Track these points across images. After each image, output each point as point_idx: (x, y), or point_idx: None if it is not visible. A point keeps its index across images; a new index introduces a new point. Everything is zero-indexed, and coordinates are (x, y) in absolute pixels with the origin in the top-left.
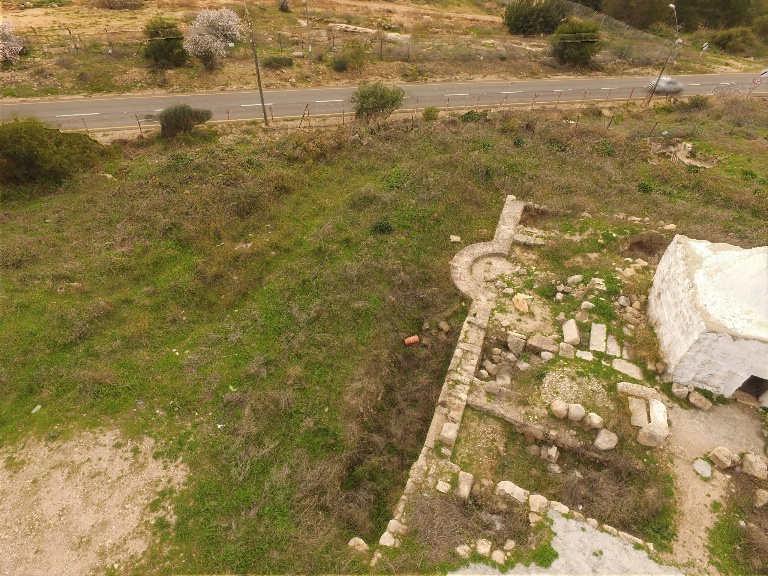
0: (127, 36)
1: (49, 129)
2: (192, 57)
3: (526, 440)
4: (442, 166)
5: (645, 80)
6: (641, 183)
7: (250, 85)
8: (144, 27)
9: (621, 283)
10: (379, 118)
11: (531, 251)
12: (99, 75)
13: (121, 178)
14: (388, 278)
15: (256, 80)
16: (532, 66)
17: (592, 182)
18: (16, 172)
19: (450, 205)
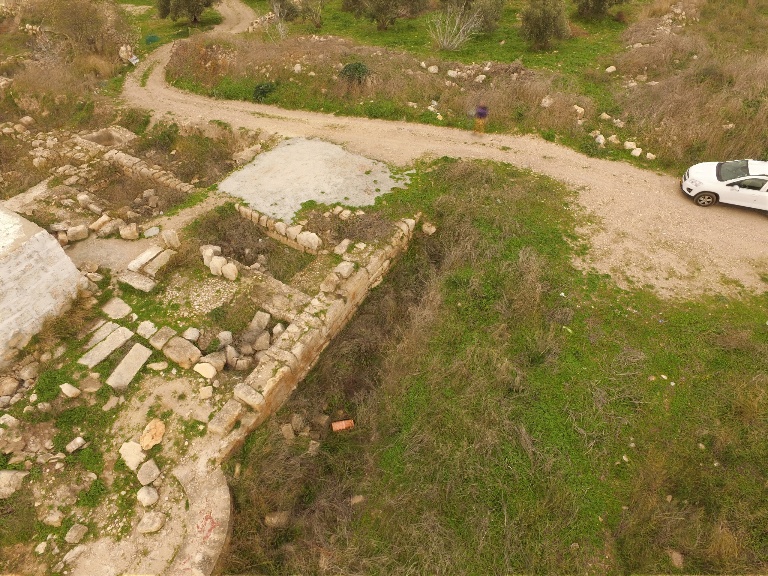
0: None
1: None
2: None
3: None
4: None
5: None
6: None
7: None
8: None
9: None
10: None
11: None
12: None
13: None
14: (357, 539)
15: None
16: None
17: None
18: None
19: None
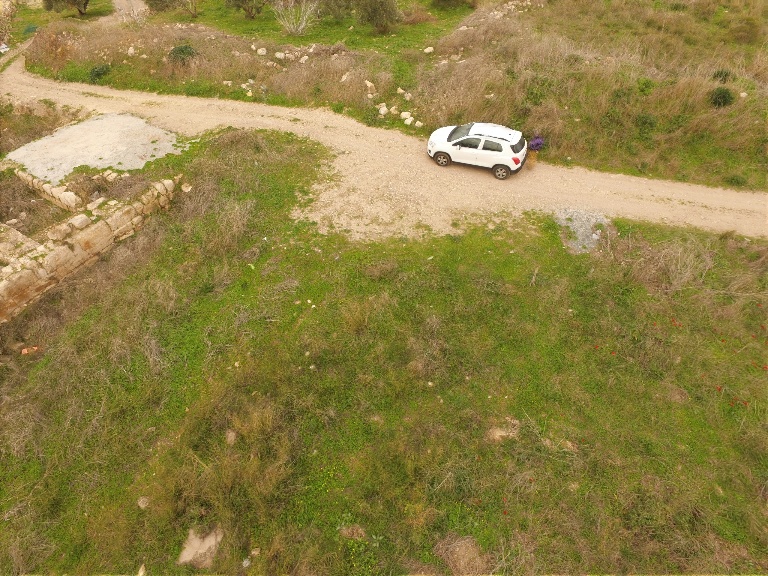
0: None
1: None
2: None
3: None
4: None
5: None
6: None
7: None
8: None
9: None
10: None
11: None
12: None
13: None
14: None
15: None
16: None
17: None
18: None
19: None
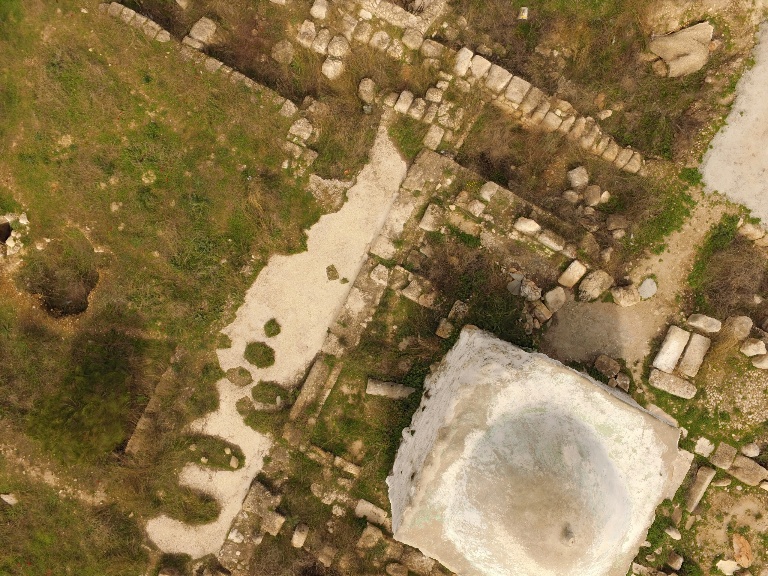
0: None
1: None
2: None
3: None
4: None
5: None
6: None
7: None
8: None
9: None
10: None
11: None
12: None
13: None
14: None
15: None
16: None
17: None
18: None
19: None
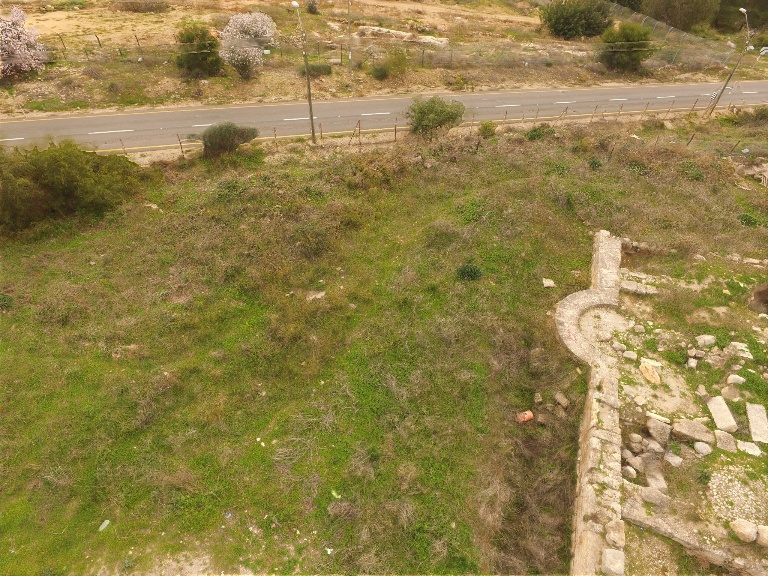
0: (171, 49)
1: (85, 152)
2: (225, 65)
3: (700, 566)
4: (519, 194)
5: (700, 87)
6: (743, 214)
7: (289, 96)
8: (177, 34)
9: (767, 349)
10: (440, 137)
11: (642, 301)
12: (130, 86)
13: (168, 209)
14: (487, 337)
15: (294, 90)
16: (579, 72)
17: (690, 214)
18: (53, 204)
19: (535, 241)
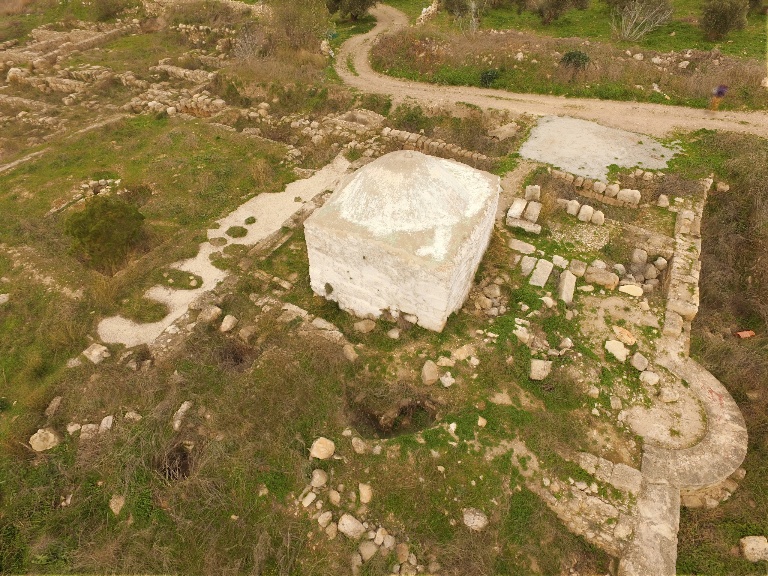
0: None
1: None
2: None
3: None
4: None
5: None
6: None
7: None
8: None
9: None
10: None
11: (599, 453)
12: None
13: None
14: None
15: None
16: None
17: None
18: None
19: None
